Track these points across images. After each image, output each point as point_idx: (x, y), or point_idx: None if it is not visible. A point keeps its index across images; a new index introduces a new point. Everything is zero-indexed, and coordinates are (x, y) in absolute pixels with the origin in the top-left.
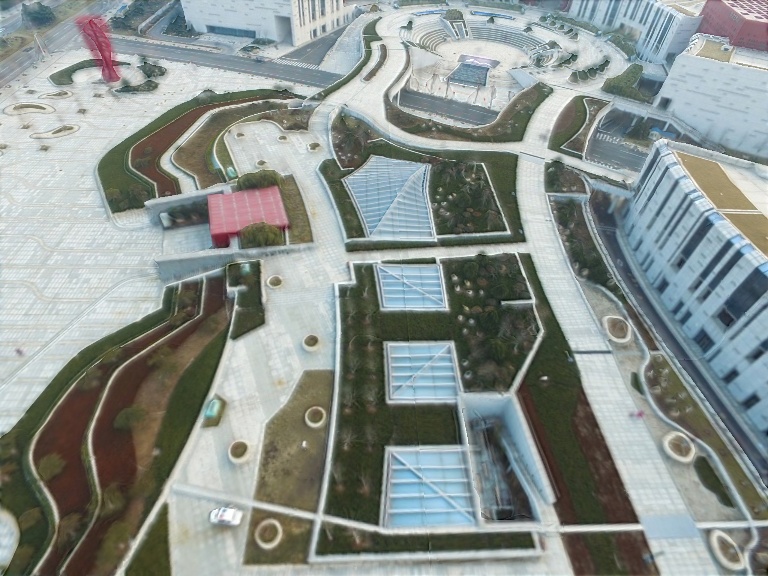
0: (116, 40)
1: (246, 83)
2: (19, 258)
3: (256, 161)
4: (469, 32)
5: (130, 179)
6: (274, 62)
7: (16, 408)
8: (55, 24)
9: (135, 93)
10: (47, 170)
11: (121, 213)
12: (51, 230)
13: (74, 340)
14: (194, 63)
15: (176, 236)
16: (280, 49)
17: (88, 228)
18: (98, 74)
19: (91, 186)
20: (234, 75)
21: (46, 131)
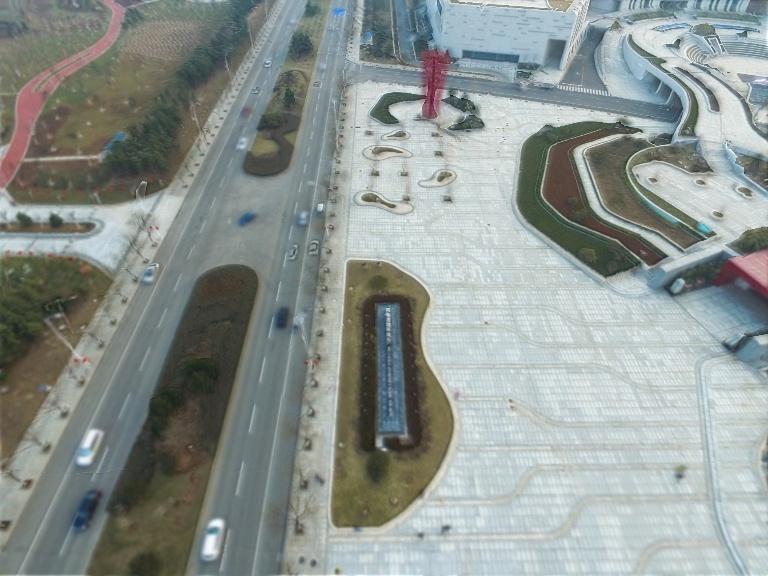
0: (386, 70)
1: (561, 115)
2: (560, 335)
3: (707, 212)
4: (723, 47)
5: (580, 235)
6: (561, 89)
7: (765, 534)
8: (315, 54)
9: (469, 131)
10: (475, 225)
11: (612, 277)
12: (556, 299)
13: (733, 441)
14: (487, 93)
15: (693, 304)
16: (550, 74)
17: (591, 295)
18: (409, 110)
19: (539, 243)
20: (540, 106)
21: (428, 178)
